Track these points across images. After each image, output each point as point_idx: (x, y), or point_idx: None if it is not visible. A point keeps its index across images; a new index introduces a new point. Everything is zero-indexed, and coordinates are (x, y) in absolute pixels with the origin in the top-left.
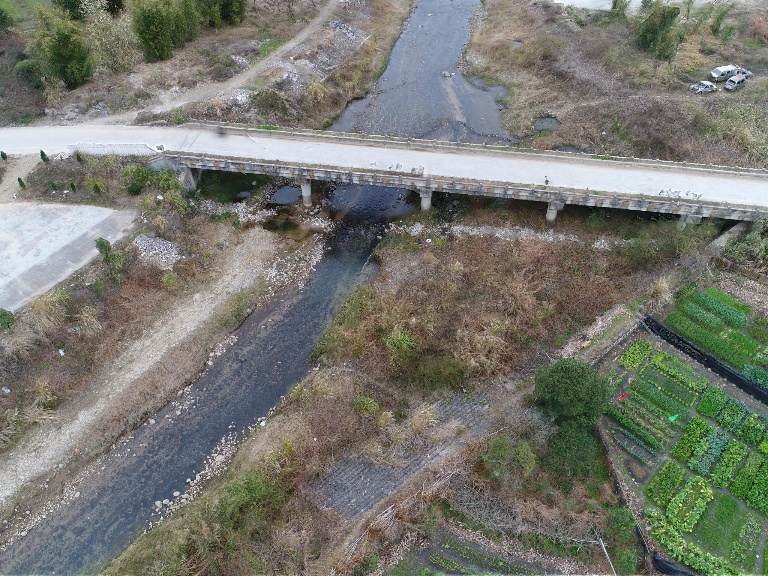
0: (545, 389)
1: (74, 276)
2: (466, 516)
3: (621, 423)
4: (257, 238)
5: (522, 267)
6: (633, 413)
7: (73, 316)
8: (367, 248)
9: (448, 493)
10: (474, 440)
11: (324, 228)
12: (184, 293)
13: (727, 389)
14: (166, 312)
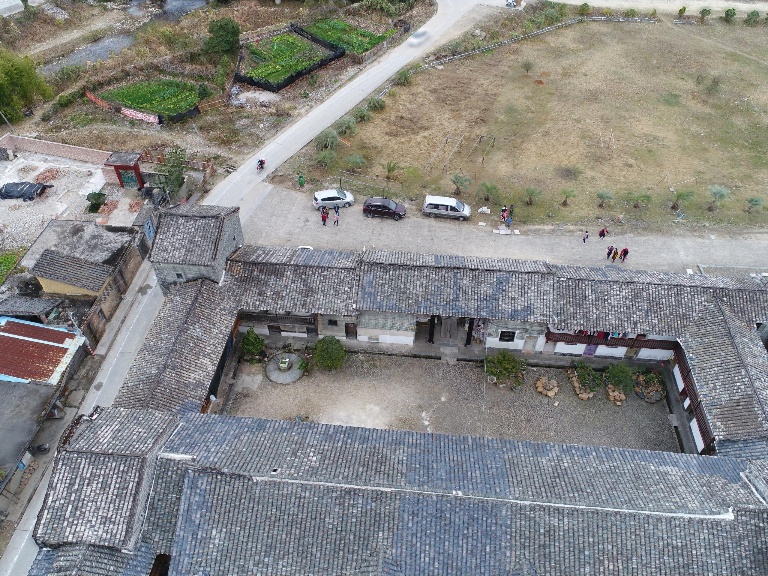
0: (211, 27)
1: (9, 16)
2: (166, 70)
3: (256, 54)
4: (114, 13)
5: None
6: (257, 45)
7: (6, 28)
8: (176, 19)
9: None
10: None
11: (155, 12)
12: (68, 30)
13: (316, 47)
14: (57, 35)
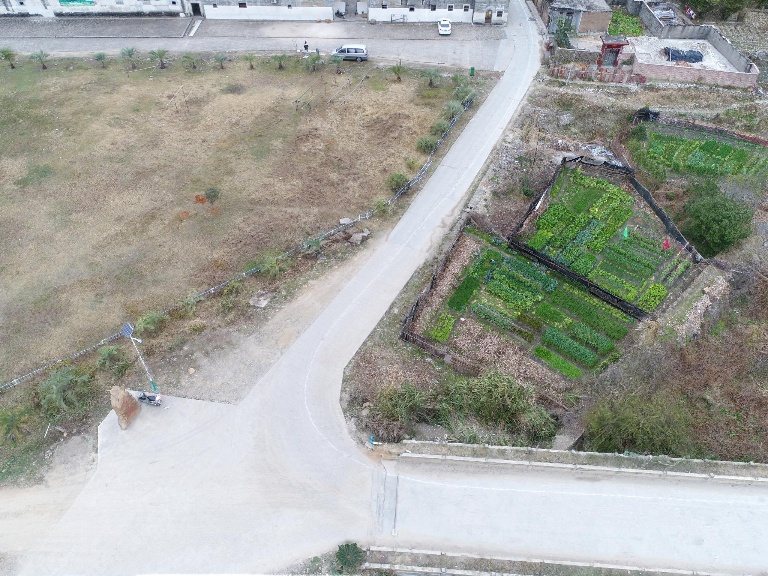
0: None
1: None
2: None
3: None
4: None
5: None
6: None
7: None
8: None
9: (763, 194)
10: (764, 219)
11: None
12: None
13: None
14: None
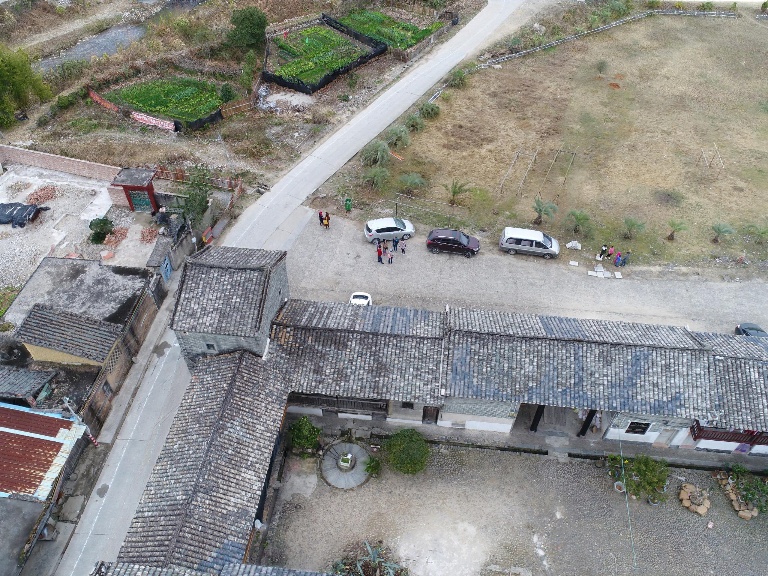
0: (234, 18)
1: None
2: (182, 67)
3: (285, 49)
4: (122, 1)
5: (270, 3)
6: (286, 38)
7: (1, 16)
8: (191, 8)
9: None
10: None
11: None
12: (71, 19)
13: None
14: (58, 25)
